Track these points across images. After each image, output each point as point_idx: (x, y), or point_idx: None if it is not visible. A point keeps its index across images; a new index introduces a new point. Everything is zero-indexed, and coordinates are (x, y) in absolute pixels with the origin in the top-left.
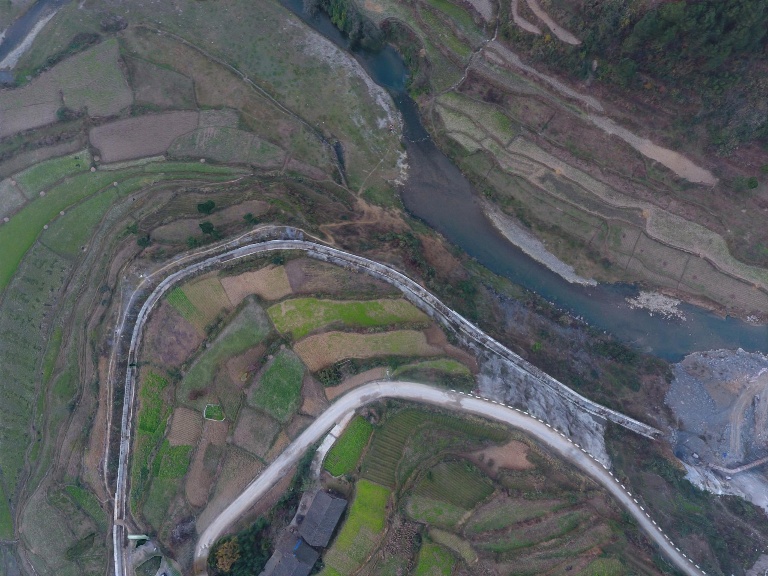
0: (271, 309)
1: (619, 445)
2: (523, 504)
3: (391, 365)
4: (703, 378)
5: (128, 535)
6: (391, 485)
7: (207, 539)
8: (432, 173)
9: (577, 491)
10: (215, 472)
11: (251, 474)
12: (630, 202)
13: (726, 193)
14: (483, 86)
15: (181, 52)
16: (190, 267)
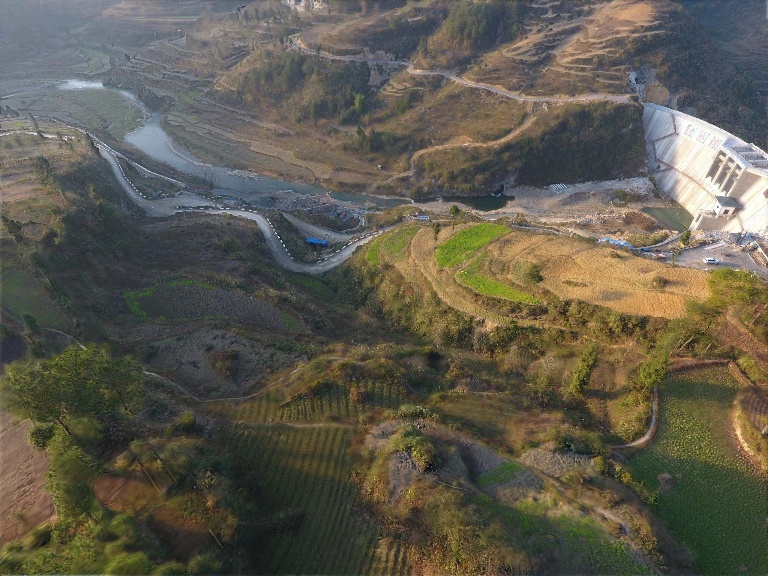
0: None
1: None
2: None
3: None
4: None
5: None
6: None
7: None
8: (150, 132)
9: None
10: None
11: None
12: (247, 140)
13: (299, 137)
14: None
15: None
16: None
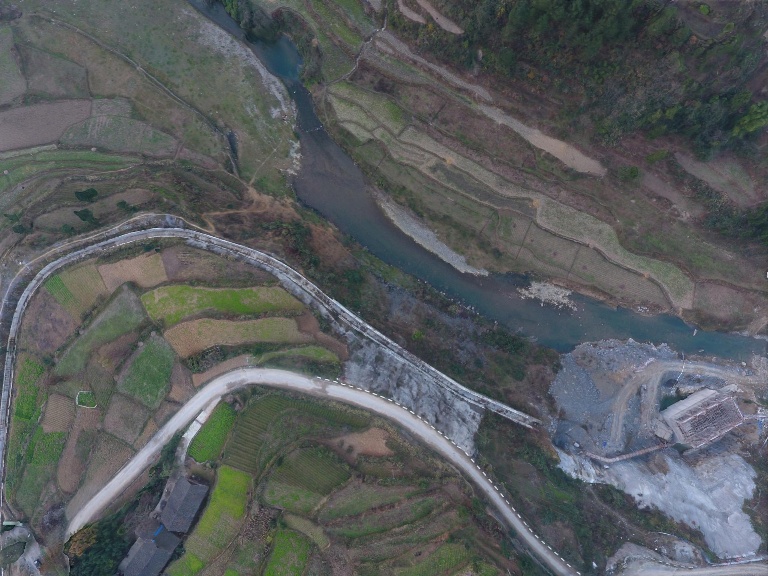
0: (144, 296)
1: (494, 433)
2: (378, 490)
3: (253, 351)
4: (590, 368)
5: (3, 522)
6: (252, 471)
7: (77, 525)
8: (325, 163)
9: (433, 477)
10: (87, 459)
11: (121, 461)
12: (520, 192)
13: (615, 183)
14: (374, 76)
15: (75, 41)
16: (71, 255)
